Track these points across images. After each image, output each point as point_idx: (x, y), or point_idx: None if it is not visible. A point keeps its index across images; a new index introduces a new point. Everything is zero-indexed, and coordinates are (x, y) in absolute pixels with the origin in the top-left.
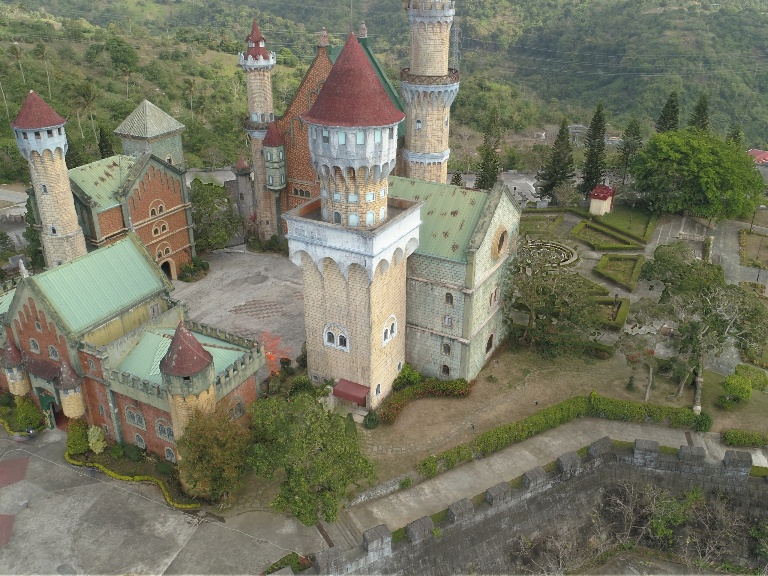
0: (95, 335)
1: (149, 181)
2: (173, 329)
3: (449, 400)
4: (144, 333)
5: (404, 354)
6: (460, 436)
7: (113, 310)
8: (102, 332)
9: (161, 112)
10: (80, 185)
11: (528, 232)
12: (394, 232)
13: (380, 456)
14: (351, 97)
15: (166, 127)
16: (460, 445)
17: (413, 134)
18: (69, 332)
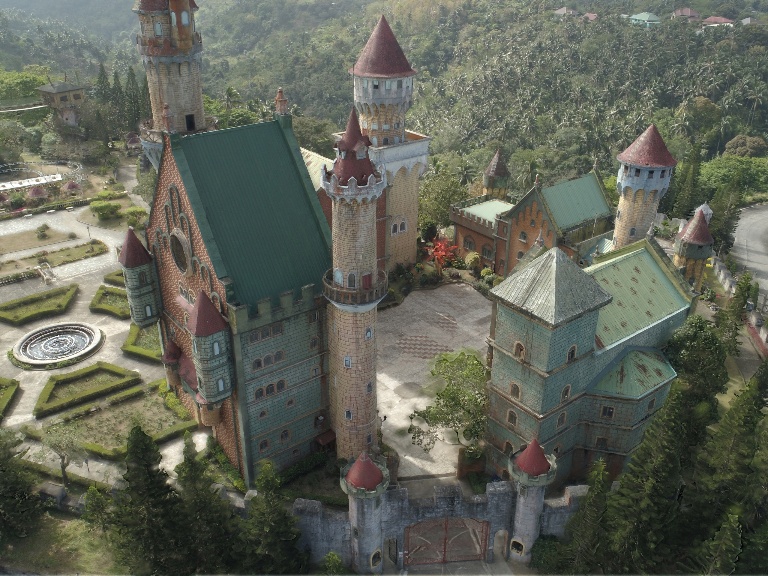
0: None
1: None
2: None
3: None
4: None
5: None
6: None
7: None
8: None
9: (530, 265)
10: None
11: None
12: None
13: None
14: None
15: None
16: None
17: None
18: None
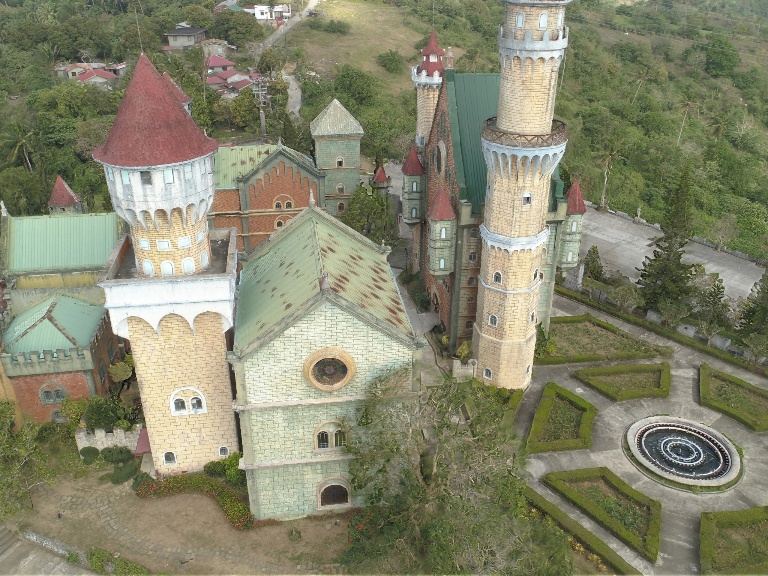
0: (33, 280)
1: (277, 175)
2: (90, 303)
3: (225, 520)
4: (54, 295)
5: (239, 442)
6: (163, 559)
7: (56, 266)
8: (41, 280)
9: (345, 113)
10: (218, 162)
11: (723, 410)
12: (160, 293)
13: (94, 516)
14: (115, 126)
15: (341, 129)
16: (139, 565)
17: (486, 202)
18: (5, 268)
